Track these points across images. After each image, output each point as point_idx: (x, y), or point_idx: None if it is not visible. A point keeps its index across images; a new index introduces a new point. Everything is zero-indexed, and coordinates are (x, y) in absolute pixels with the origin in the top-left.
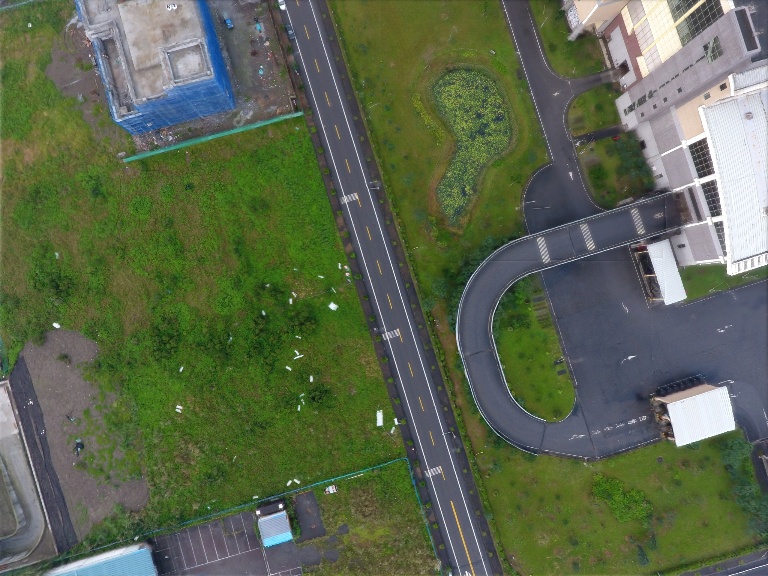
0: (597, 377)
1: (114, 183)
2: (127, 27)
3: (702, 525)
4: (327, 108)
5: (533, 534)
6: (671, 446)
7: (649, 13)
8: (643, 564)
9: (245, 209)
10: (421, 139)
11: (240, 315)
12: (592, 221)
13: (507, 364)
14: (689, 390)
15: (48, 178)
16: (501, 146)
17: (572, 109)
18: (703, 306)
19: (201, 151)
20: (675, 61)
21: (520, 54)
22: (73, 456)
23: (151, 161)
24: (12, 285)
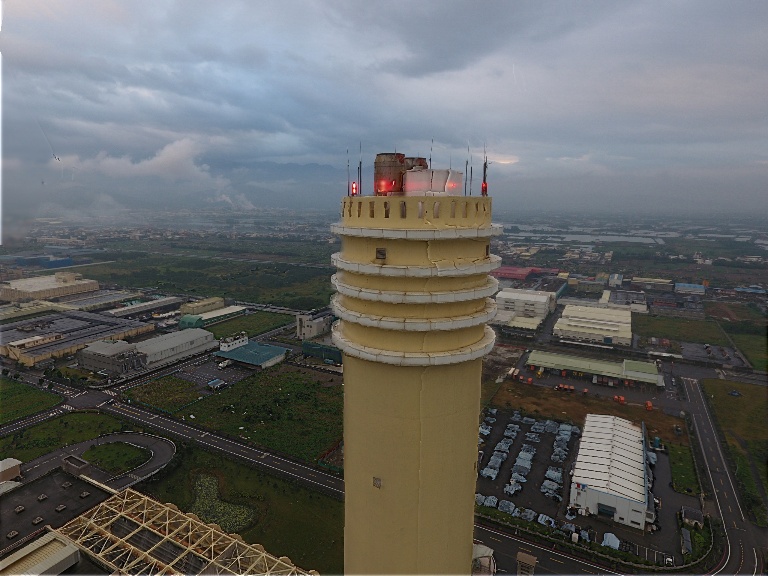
0: None
1: None
2: None
3: None
4: None
5: None
6: None
7: None
8: None
9: None
10: (244, 487)
11: None
12: None
13: None
14: None
15: None
16: None
17: None
18: None
19: None
20: None
21: None
22: None
23: None
24: None
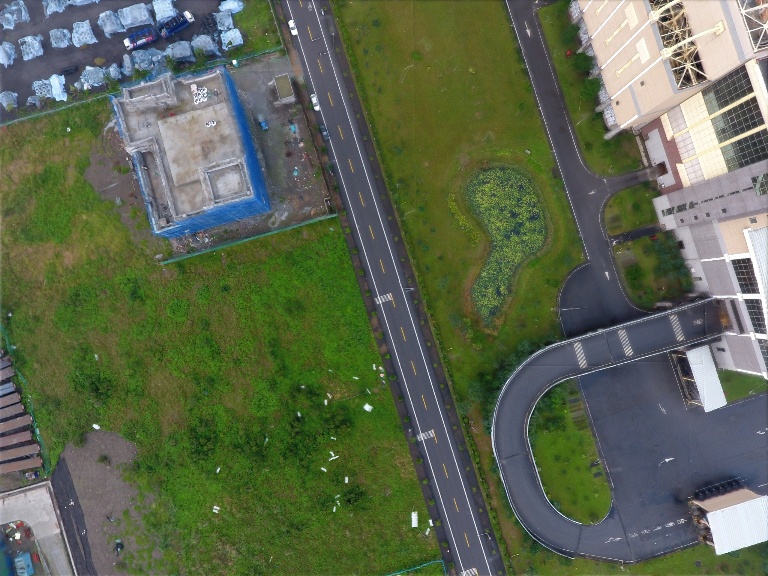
0: (634, 479)
1: (152, 285)
2: (167, 144)
3: None
4: (361, 208)
5: None
6: (710, 550)
7: (691, 127)
8: None
9: (280, 311)
10: (455, 240)
11: (276, 416)
12: (630, 327)
13: (543, 466)
14: (729, 495)
15: (87, 281)
16: (536, 245)
17: (608, 208)
18: (743, 408)
19: (237, 253)
20: (720, 183)
21: (555, 152)
22: (113, 556)
23: (188, 263)
24: (53, 387)
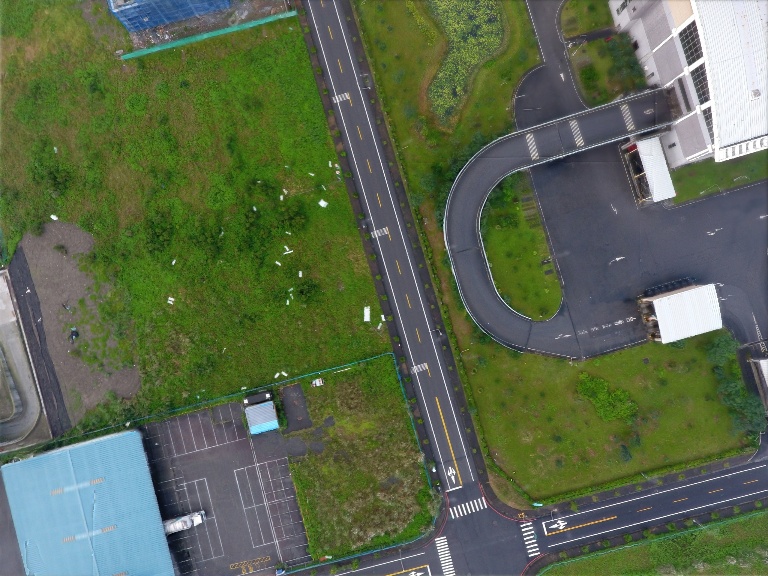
0: (584, 278)
1: (111, 80)
2: None
3: (687, 426)
4: (320, 9)
5: (517, 431)
6: (658, 348)
7: None
8: (626, 460)
9: (238, 107)
10: (413, 39)
11: (232, 210)
12: (581, 117)
13: (494, 263)
14: (677, 290)
15: (48, 74)
16: (493, 48)
17: (565, 11)
18: (693, 209)
19: (196, 49)
20: None
21: None
22: (68, 344)
23: (148, 59)
24: (12, 178)
